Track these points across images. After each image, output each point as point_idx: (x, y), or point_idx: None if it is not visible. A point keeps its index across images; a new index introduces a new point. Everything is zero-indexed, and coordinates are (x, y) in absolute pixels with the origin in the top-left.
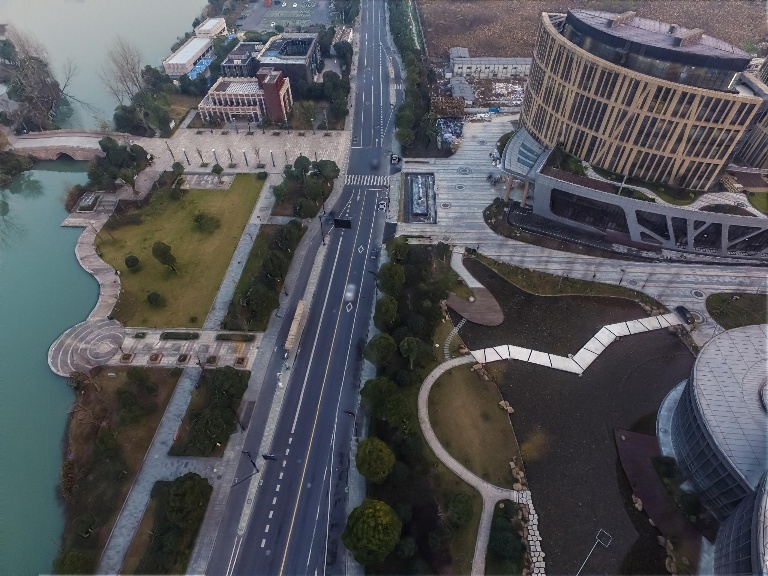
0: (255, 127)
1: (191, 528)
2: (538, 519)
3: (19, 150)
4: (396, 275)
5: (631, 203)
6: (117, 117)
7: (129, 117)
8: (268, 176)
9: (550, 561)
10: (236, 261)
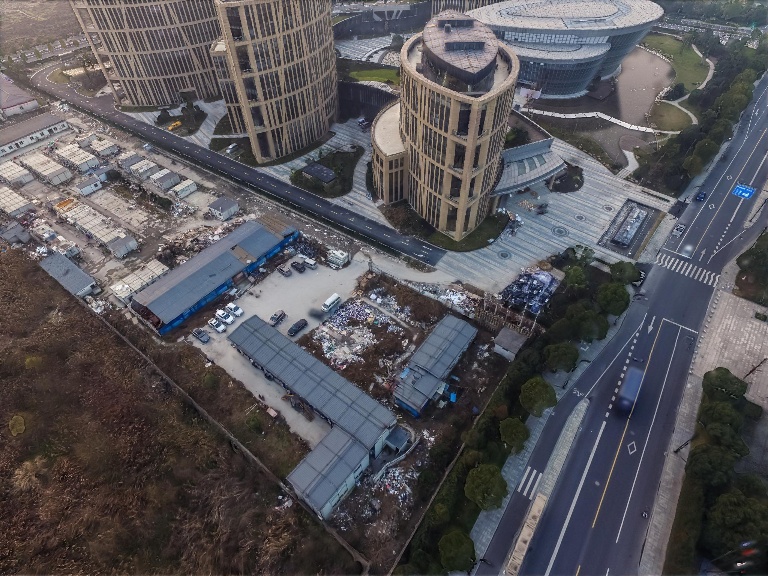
0: None
1: None
2: None
3: None
4: None
5: None
6: None
7: None
8: None
9: (658, 92)
10: None
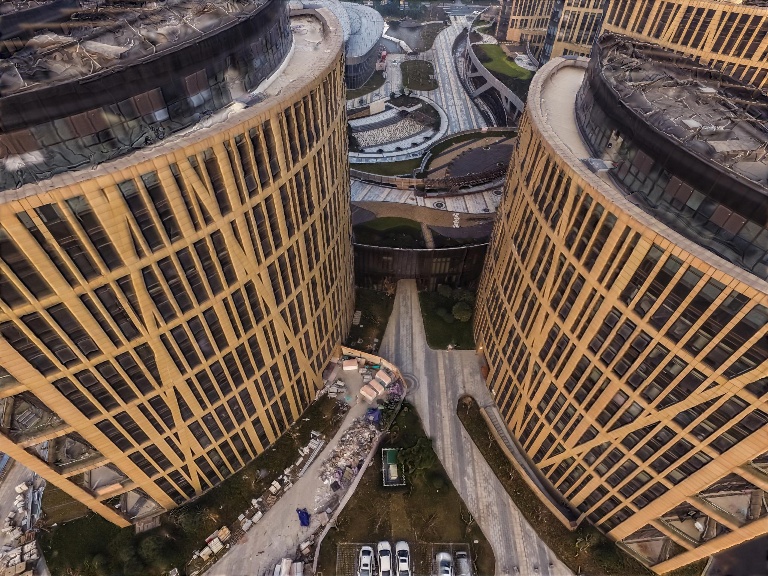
0: None
1: None
2: None
3: None
4: None
5: None
6: None
7: None
8: None
9: None
10: None
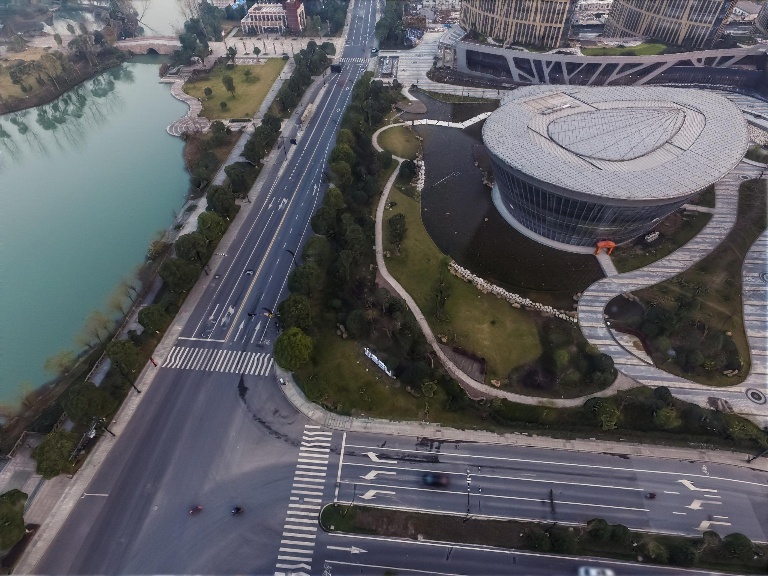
0: (280, 36)
1: (255, 174)
2: (425, 169)
3: (122, 47)
4: (364, 83)
5: (509, 52)
6: (187, 26)
7: (195, 25)
8: (289, 59)
9: (428, 179)
10: (271, 94)
